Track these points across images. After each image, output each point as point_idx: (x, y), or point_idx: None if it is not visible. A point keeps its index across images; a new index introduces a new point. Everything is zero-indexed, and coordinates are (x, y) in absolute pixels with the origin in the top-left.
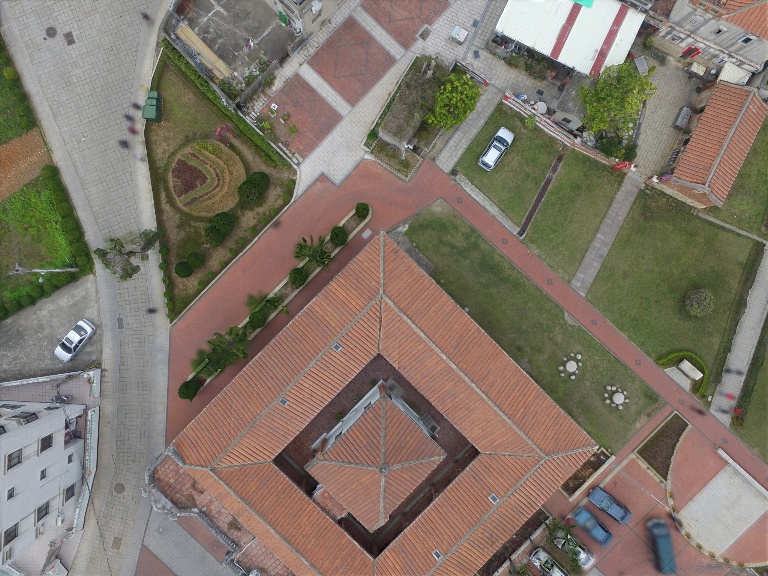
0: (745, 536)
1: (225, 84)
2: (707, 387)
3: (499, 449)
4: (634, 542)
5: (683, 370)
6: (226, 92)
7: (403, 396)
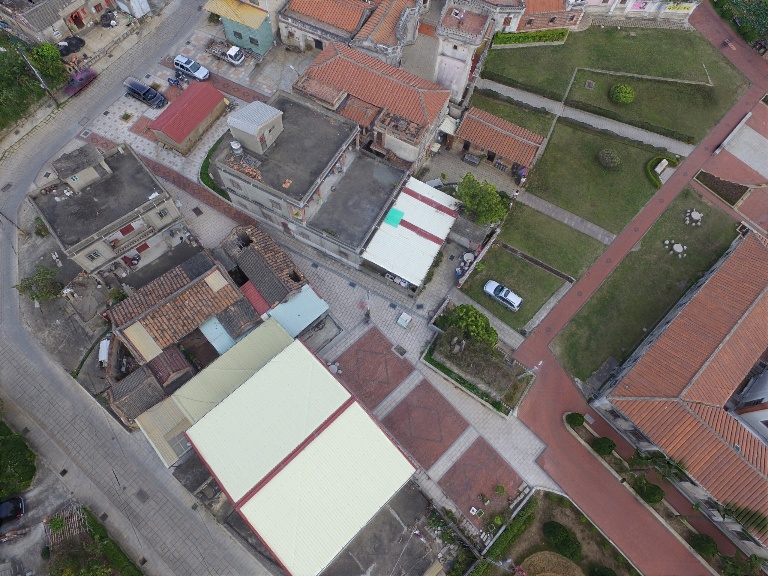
0: None
1: (455, 569)
2: None
3: None
4: None
5: (661, 172)
6: (465, 568)
7: (737, 392)
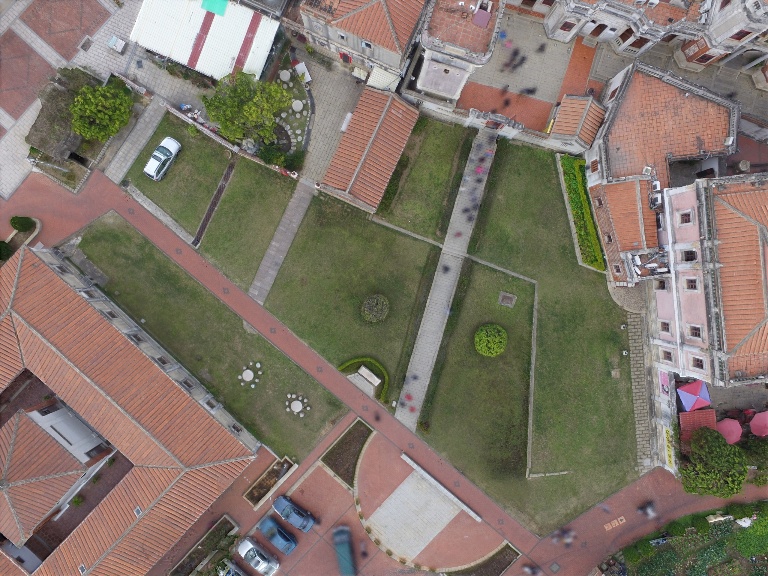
0: (436, 541)
1: None
2: (391, 393)
3: (148, 461)
4: (325, 550)
5: None
6: None
7: None
